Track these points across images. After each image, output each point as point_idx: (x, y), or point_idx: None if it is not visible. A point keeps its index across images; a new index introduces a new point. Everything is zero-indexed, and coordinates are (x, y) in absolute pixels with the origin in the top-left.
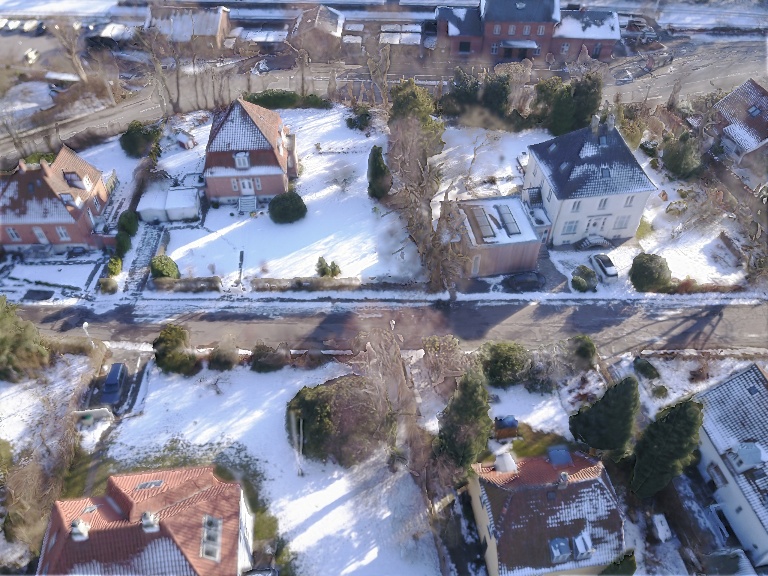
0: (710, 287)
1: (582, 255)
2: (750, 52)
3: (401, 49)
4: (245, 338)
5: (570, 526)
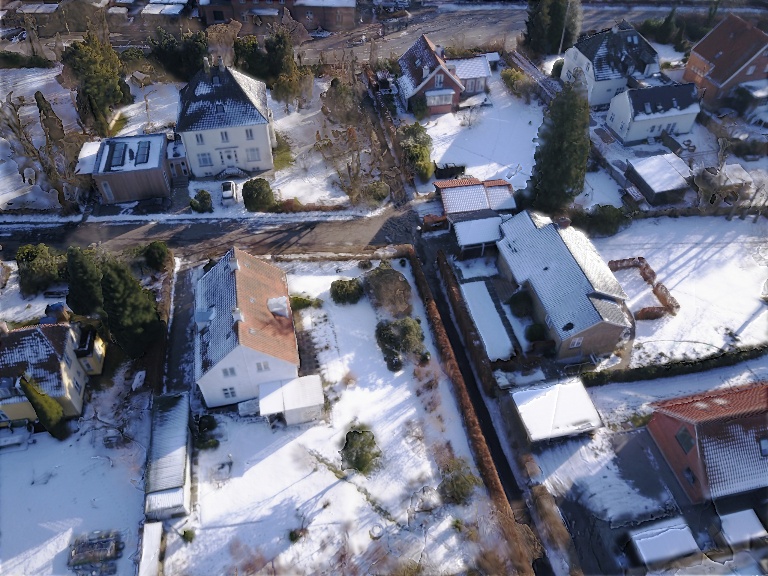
0: (312, 206)
1: (218, 184)
2: (484, 19)
3: (164, 19)
4: None
5: (14, 368)
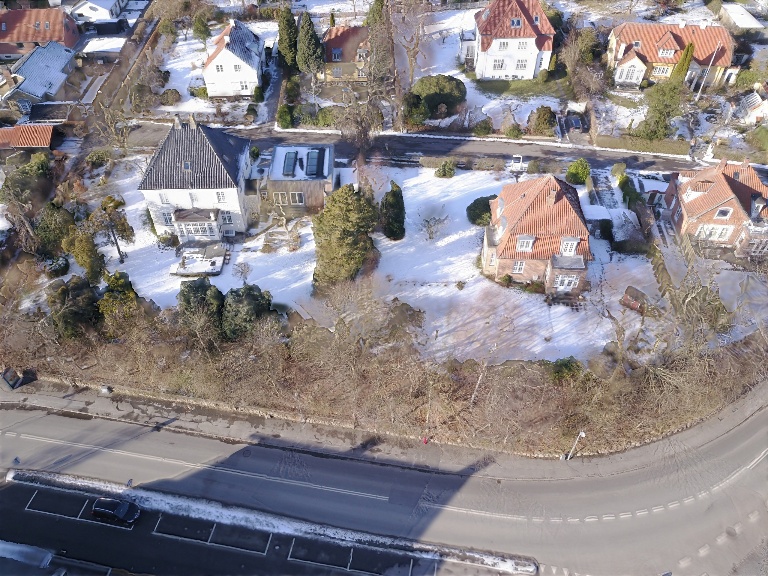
0: None
1: None
2: None
3: None
4: (502, 147)
5: None
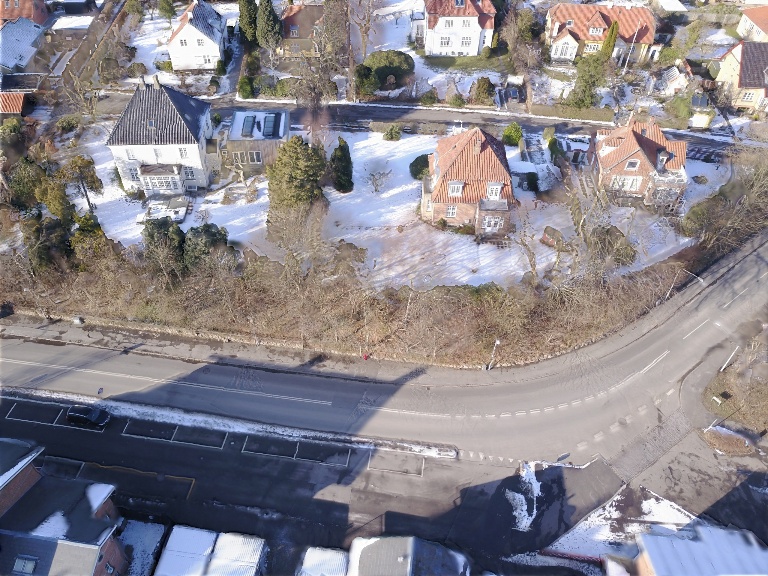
0: None
1: None
2: None
3: None
4: (446, 115)
5: None
